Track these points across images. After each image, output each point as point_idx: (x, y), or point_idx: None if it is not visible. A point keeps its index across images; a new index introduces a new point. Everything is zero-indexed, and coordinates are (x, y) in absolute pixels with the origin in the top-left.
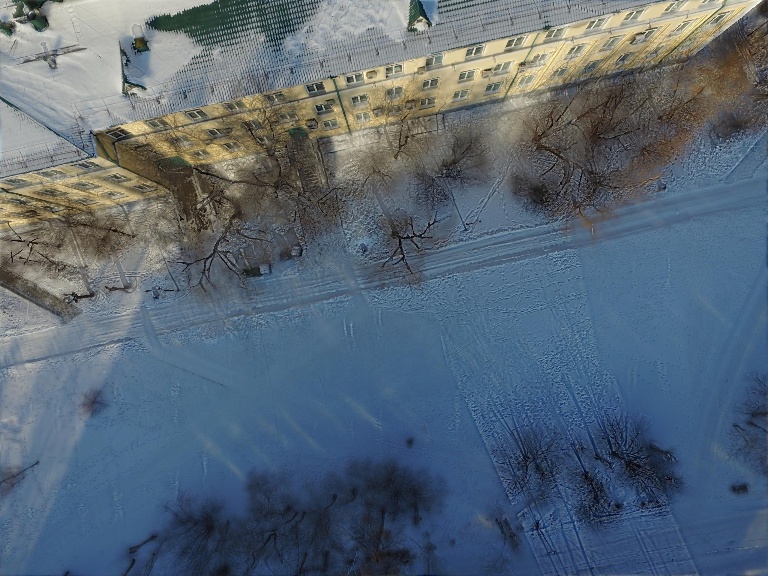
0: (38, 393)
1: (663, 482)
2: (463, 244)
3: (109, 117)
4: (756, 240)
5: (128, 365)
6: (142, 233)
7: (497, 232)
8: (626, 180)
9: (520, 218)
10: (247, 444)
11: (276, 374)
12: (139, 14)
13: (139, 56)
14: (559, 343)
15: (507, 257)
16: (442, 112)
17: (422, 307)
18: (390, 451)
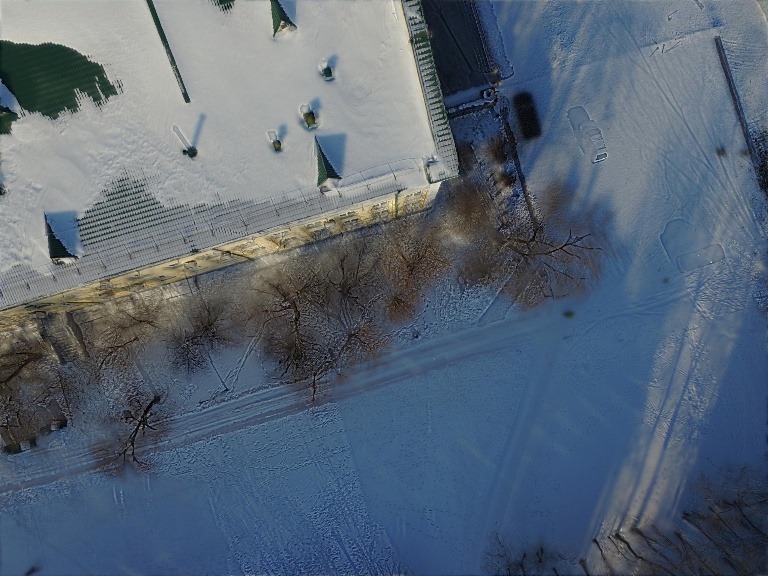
0: None
1: None
2: (225, 404)
3: None
4: (511, 382)
5: None
6: None
7: (257, 390)
8: (380, 330)
9: (279, 375)
10: None
11: (49, 547)
12: None
13: None
14: (326, 498)
15: (269, 414)
16: (192, 276)
17: (190, 470)
18: None
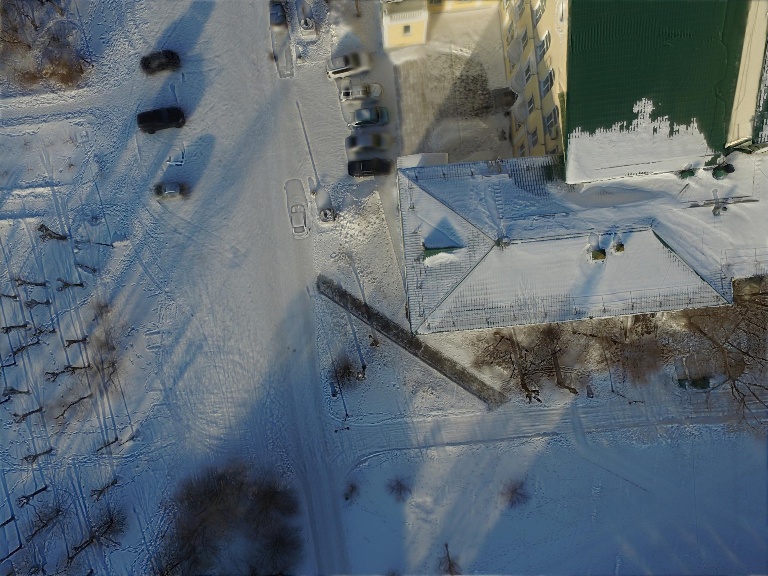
0: (455, 477)
1: None
2: None
3: (754, 267)
4: None
5: (551, 459)
6: (583, 330)
7: None
8: None
9: None
10: (665, 552)
11: (702, 485)
12: None
13: None
14: None
15: None
16: None
17: None
18: None
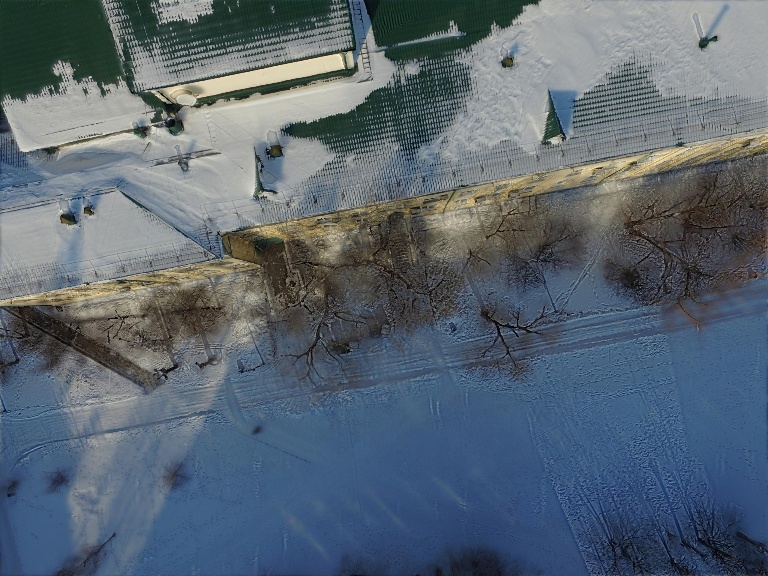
0: (117, 464)
1: (749, 571)
2: (552, 326)
3: (237, 219)
4: None
5: (210, 438)
6: (229, 305)
7: (587, 315)
8: (717, 267)
9: (610, 301)
10: (329, 522)
11: (360, 451)
12: (275, 121)
13: (272, 161)
14: (647, 428)
15: (596, 340)
16: (535, 194)
17: (510, 388)
18: (474, 532)
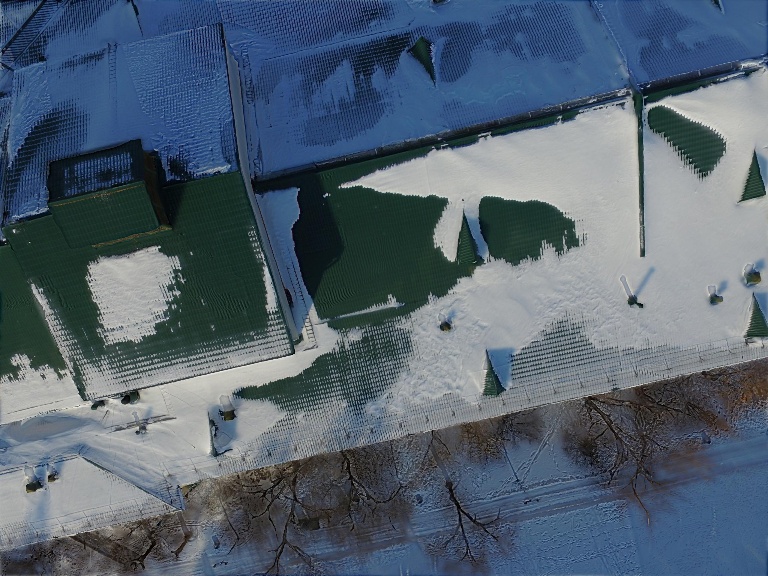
0: None
1: None
2: (515, 494)
3: (196, 473)
4: None
5: None
6: (202, 483)
7: (548, 483)
8: (672, 433)
9: (570, 469)
10: None
11: None
12: (227, 387)
13: (226, 421)
14: None
15: (558, 507)
16: None
17: (476, 555)
18: None
